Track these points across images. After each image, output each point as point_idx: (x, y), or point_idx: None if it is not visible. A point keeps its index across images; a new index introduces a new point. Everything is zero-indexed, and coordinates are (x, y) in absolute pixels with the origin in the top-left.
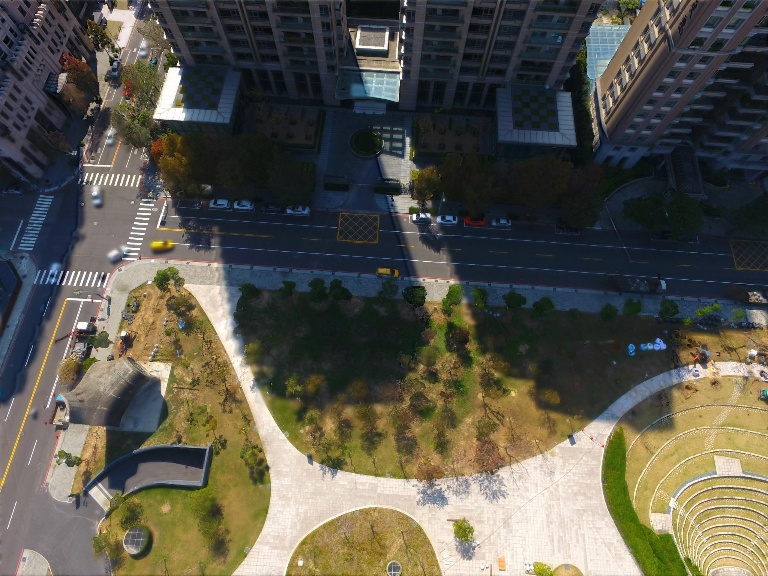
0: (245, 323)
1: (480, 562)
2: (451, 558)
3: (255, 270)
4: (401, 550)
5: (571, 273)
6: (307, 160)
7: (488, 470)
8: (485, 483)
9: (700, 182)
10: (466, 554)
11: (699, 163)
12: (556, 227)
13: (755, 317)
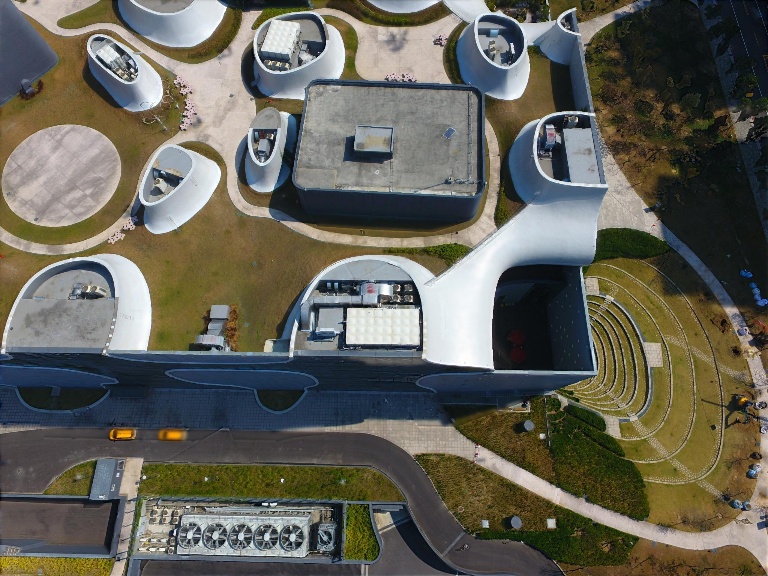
0: None
1: None
2: None
3: (714, 6)
4: None
5: None
6: None
7: None
8: None
9: None
10: None
11: None
12: None
13: None
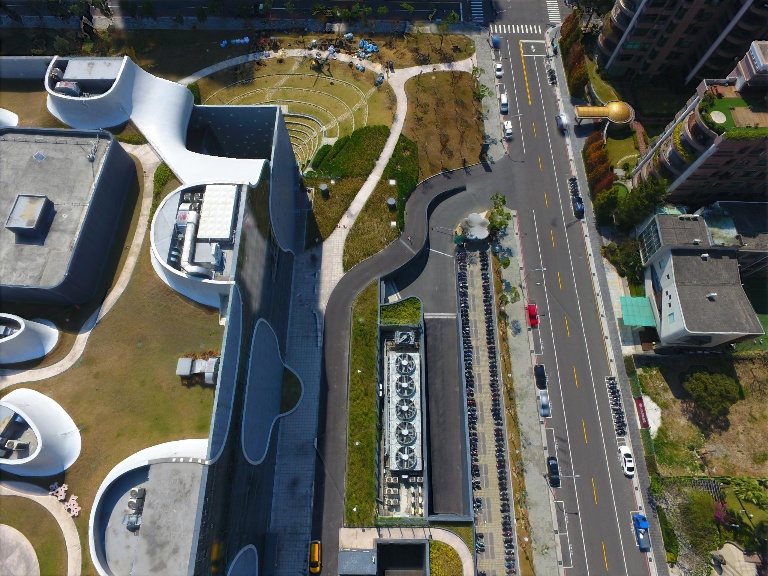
0: None
1: None
2: None
3: None
4: None
5: (203, 8)
6: None
7: None
8: None
9: None
10: None
11: None
12: None
13: (332, 27)
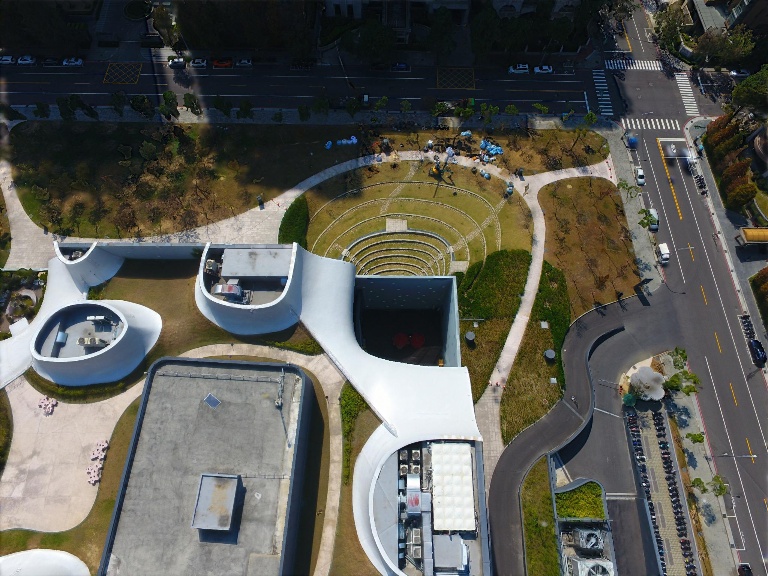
0: (1, 134)
1: None
2: None
3: (29, 107)
4: None
5: (297, 98)
6: None
7: (170, 215)
8: (183, 238)
9: (408, 20)
10: None
11: None
12: (291, 65)
13: (445, 122)
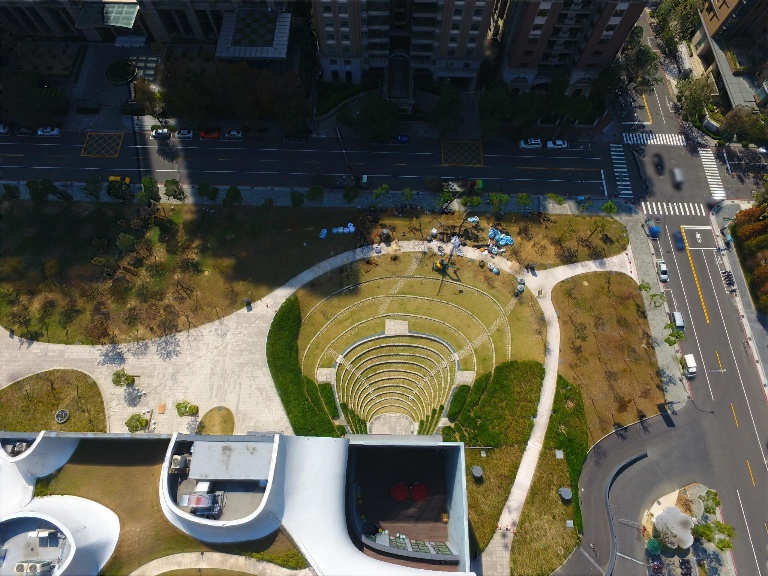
0: None
1: (143, 408)
2: (118, 406)
3: None
4: (73, 401)
5: (290, 175)
6: (65, 89)
7: (146, 326)
8: (162, 345)
9: (411, 89)
10: (132, 402)
11: (425, 77)
12: (284, 137)
13: (450, 204)
